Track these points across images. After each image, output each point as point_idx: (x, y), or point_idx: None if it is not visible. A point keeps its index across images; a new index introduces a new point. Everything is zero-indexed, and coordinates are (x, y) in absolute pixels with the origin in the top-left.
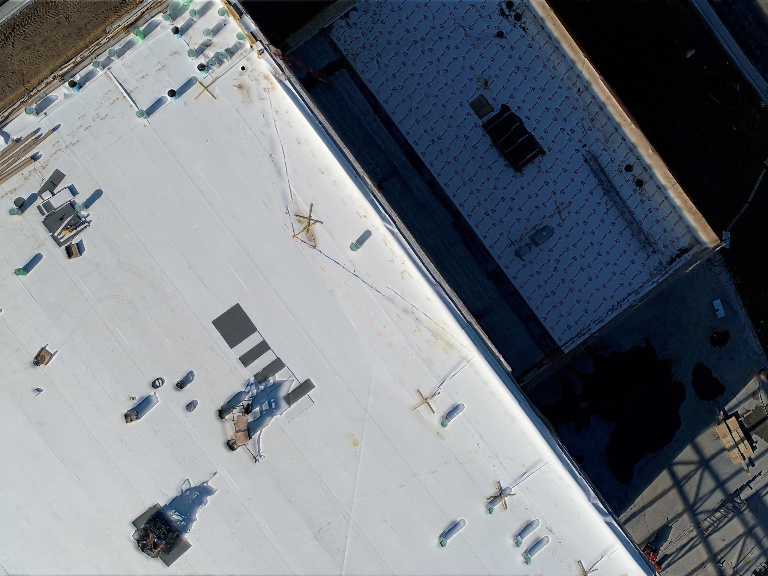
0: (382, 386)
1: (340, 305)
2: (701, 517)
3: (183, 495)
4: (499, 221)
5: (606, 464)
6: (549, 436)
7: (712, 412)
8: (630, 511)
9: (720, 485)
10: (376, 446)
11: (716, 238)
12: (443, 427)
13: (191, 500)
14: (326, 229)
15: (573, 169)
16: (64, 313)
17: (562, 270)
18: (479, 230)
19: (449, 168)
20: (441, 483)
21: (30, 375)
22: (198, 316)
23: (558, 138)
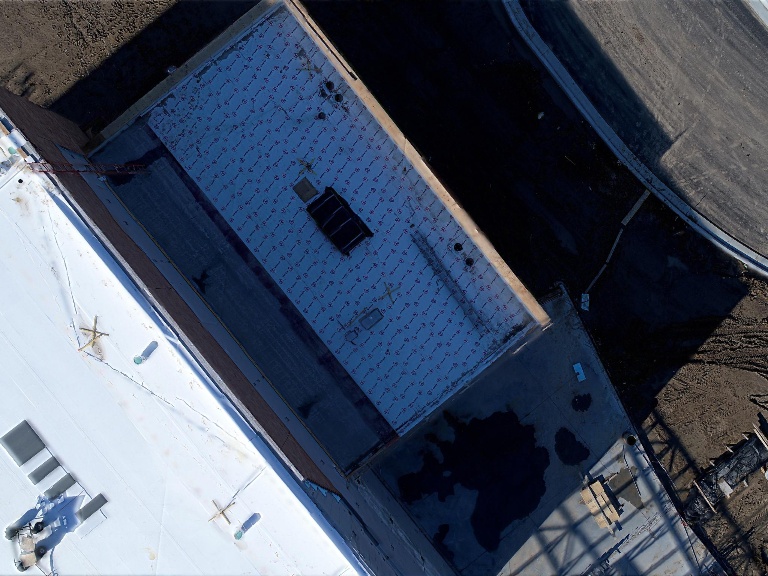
0: (176, 498)
1: (129, 418)
2: None
3: None
4: (328, 305)
5: (471, 533)
6: (344, 545)
7: (576, 477)
8: None
9: (587, 550)
10: (172, 559)
11: (546, 316)
12: None
13: None
14: (112, 341)
15: (402, 250)
16: None
17: (394, 352)
18: (308, 315)
19: (275, 254)
20: None
21: None
22: None
23: (385, 219)
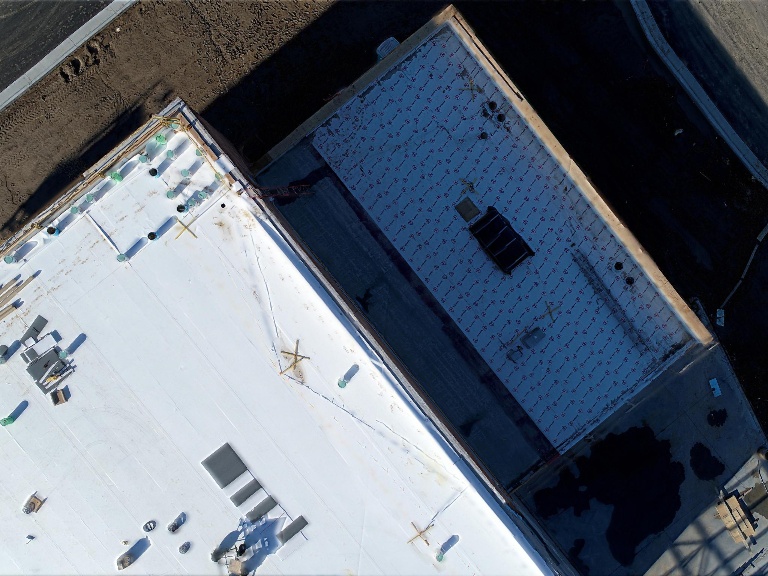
0: (375, 520)
1: (330, 440)
2: None
3: None
4: (490, 324)
5: (607, 547)
6: (545, 567)
7: (712, 491)
8: None
9: (722, 564)
10: None
11: (709, 335)
12: (438, 560)
13: None
14: (313, 364)
15: (562, 269)
16: (52, 460)
17: (555, 371)
18: (470, 334)
19: (437, 273)
20: None
21: (20, 523)
22: (187, 457)
23: (546, 238)
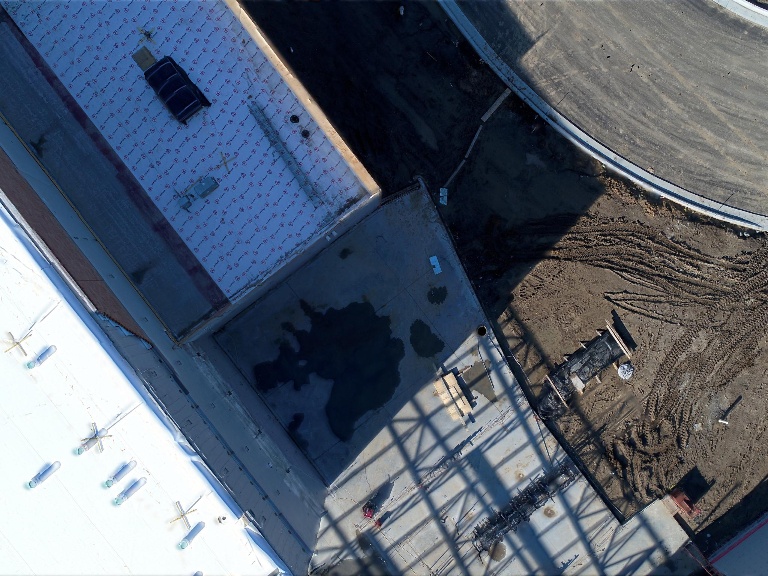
0: None
1: None
2: (422, 473)
3: None
4: (164, 173)
5: (326, 422)
6: (134, 376)
7: (431, 368)
8: (351, 468)
9: (441, 441)
10: None
11: (377, 187)
12: None
13: None
14: None
15: (239, 120)
16: None
17: (229, 221)
18: (144, 182)
19: (113, 120)
20: (35, 425)
21: None
22: None
23: (223, 89)
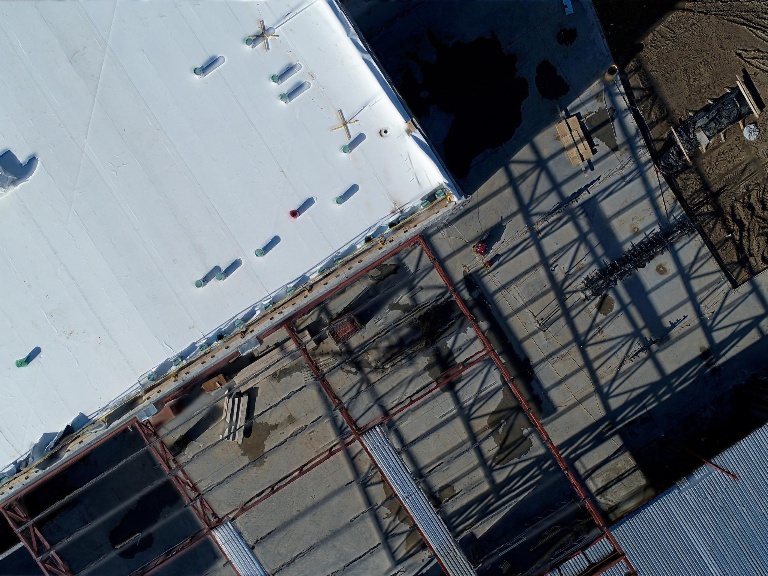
0: None
1: None
2: (536, 218)
3: None
4: None
5: (443, 157)
6: None
7: (554, 111)
8: None
9: (557, 187)
10: None
11: None
12: None
13: None
14: None
15: None
16: None
17: None
18: None
19: None
20: (202, 17)
21: None
22: None
23: None
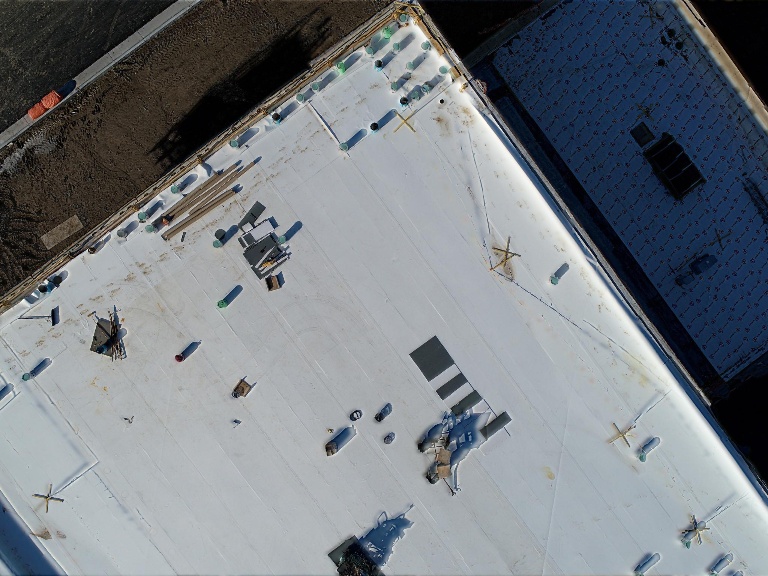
0: (578, 419)
1: (537, 338)
2: None
3: (380, 528)
4: (659, 249)
5: None
6: (748, 471)
7: None
8: None
9: None
10: (572, 479)
11: None
12: (640, 461)
13: (388, 533)
14: (523, 262)
15: (733, 197)
16: (263, 345)
17: (722, 298)
18: (639, 258)
19: (610, 196)
20: (636, 517)
21: (228, 407)
22: (396, 348)
23: (718, 166)
